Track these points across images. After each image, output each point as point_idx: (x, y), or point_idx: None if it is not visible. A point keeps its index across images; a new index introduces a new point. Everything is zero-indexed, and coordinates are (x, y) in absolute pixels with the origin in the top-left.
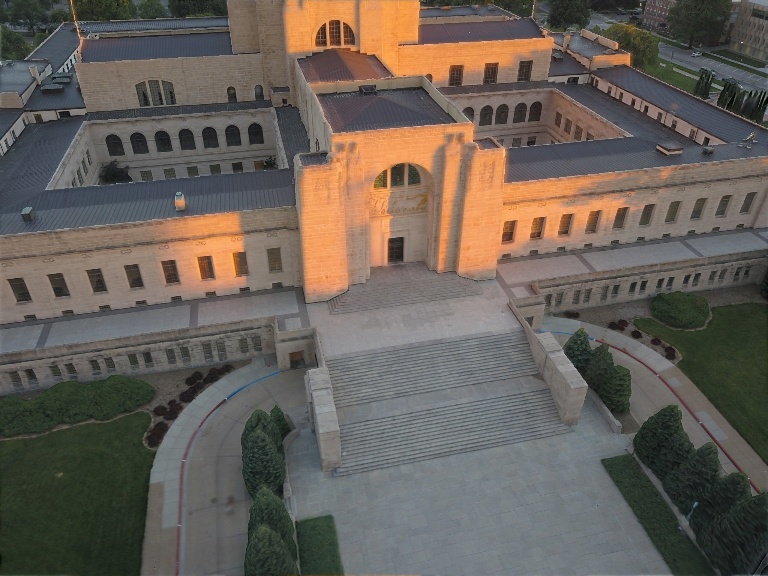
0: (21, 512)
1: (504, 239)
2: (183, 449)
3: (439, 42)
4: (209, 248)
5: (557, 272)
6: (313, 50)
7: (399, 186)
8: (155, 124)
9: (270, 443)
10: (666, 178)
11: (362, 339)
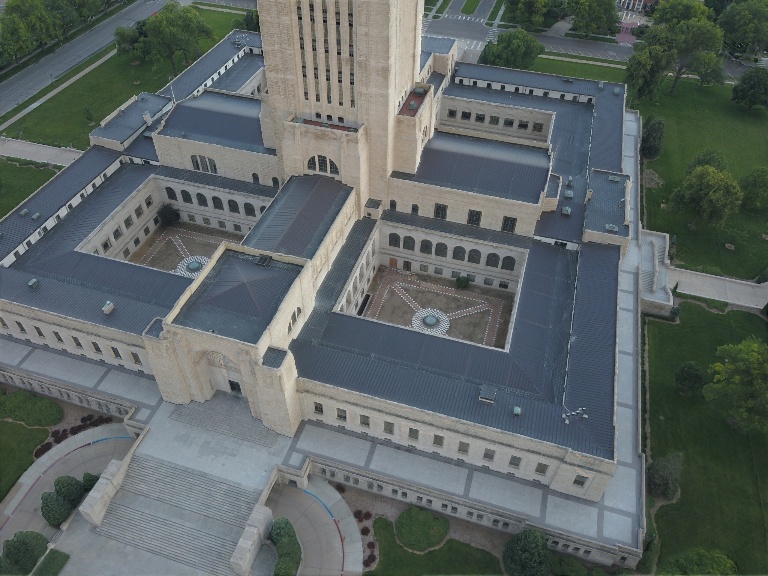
0: None
1: (318, 409)
2: (47, 467)
3: (437, 176)
4: (114, 344)
5: (340, 453)
6: (305, 172)
7: None
8: (196, 188)
9: (54, 501)
10: (449, 424)
11: (166, 448)
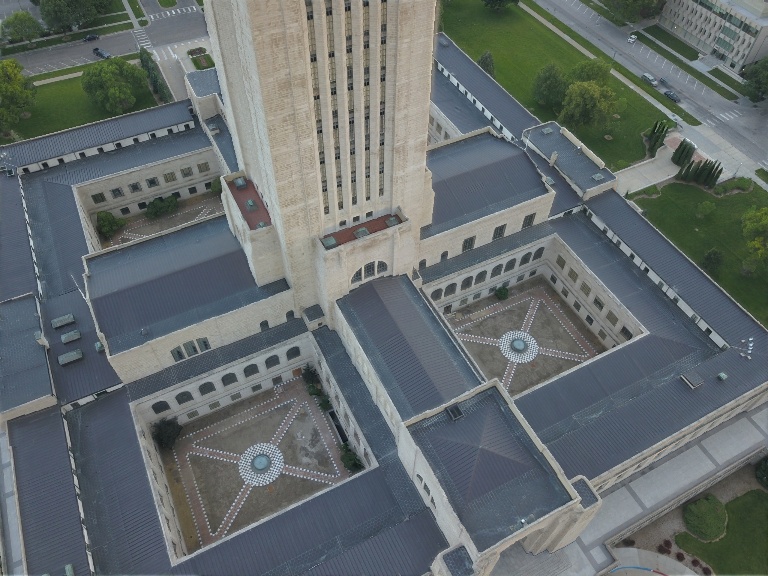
0: None
1: None
2: None
3: (449, 213)
4: None
5: (618, 517)
6: (350, 289)
7: None
8: (199, 381)
9: None
10: None
11: None
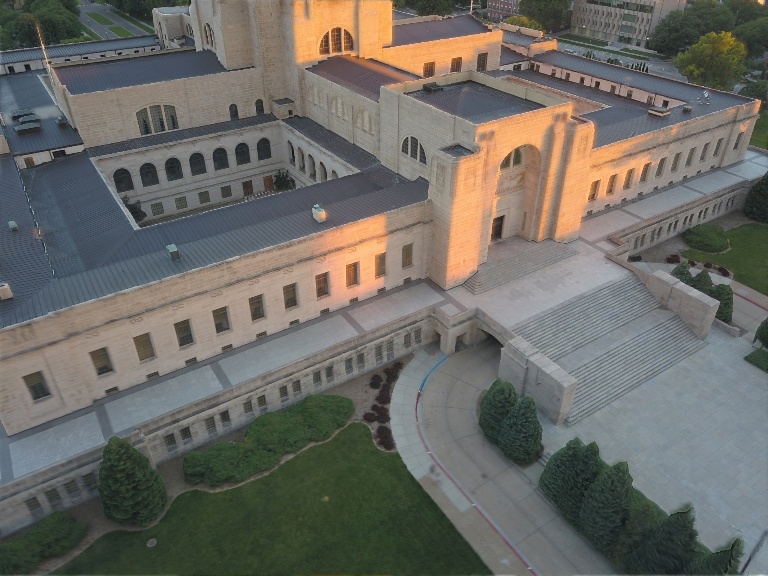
0: (320, 542)
1: None
2: (420, 443)
3: (407, 42)
4: (358, 254)
5: (618, 225)
6: (318, 59)
7: (505, 168)
8: (166, 151)
9: None
10: (674, 134)
11: (520, 308)
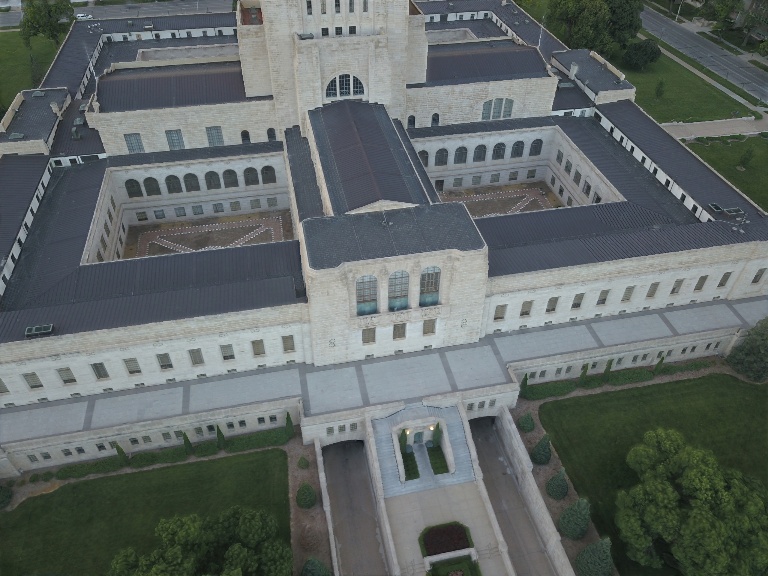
0: None
1: None
2: None
3: None
4: None
5: None
6: None
7: None
8: None
9: None
10: None
11: None
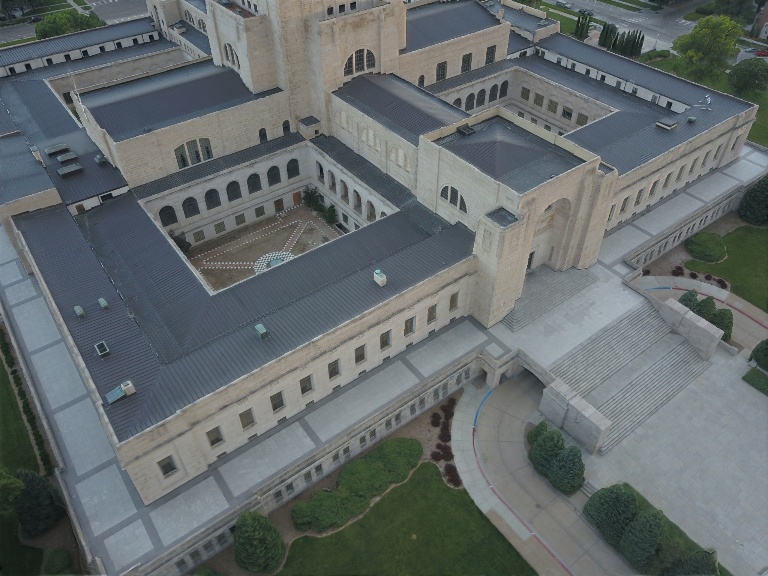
0: None
1: None
2: (482, 478)
3: (420, 42)
4: (415, 310)
5: (630, 244)
6: (343, 81)
7: None
8: (205, 185)
9: None
10: (681, 152)
11: (555, 345)
